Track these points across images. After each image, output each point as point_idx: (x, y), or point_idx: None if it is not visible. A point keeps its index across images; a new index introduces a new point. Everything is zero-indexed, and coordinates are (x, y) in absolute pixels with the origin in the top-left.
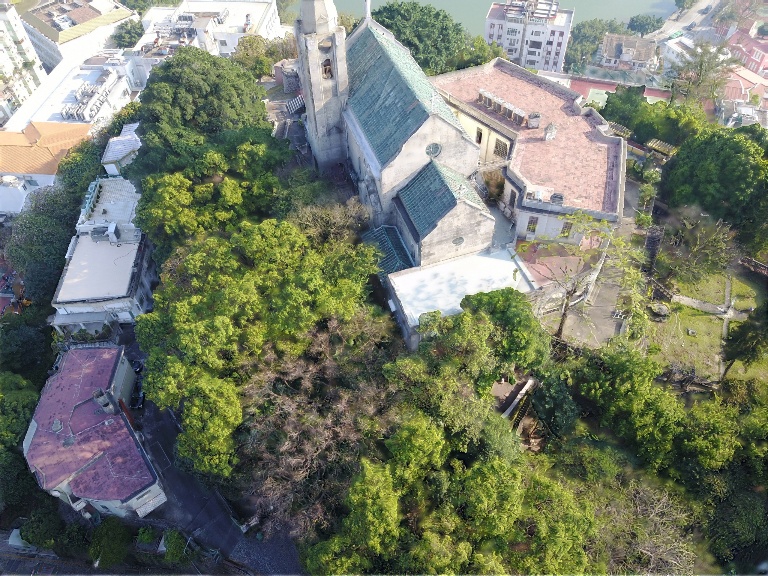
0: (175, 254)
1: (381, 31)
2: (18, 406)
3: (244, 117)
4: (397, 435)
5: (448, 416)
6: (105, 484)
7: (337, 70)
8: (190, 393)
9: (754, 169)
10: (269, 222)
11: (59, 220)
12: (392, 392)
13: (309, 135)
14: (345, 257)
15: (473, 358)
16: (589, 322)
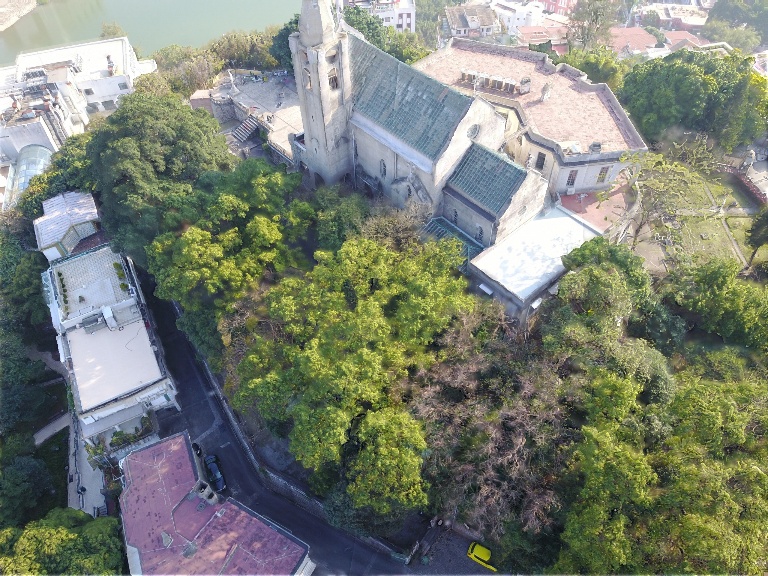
0: (224, 312)
1: (353, 33)
2: (105, 538)
3: (216, 154)
4: (595, 397)
5: (625, 364)
6: (257, 575)
7: (343, 78)
8: (365, 436)
9: (702, 86)
10: (348, 244)
11: (3, 328)
12: (563, 361)
13: (307, 153)
14: (431, 256)
15: (622, 305)
16: (675, 245)
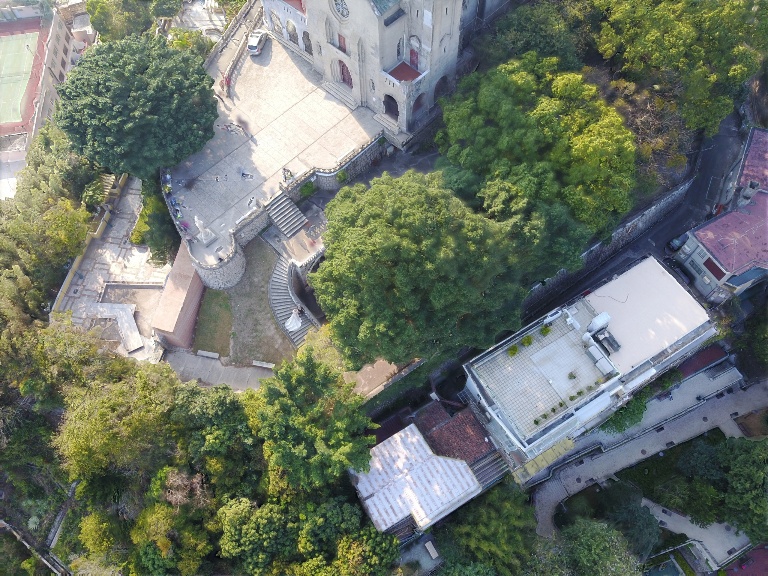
0: None
1: None
2: None
3: None
4: None
5: None
6: None
7: None
8: None
9: None
10: None
11: None
12: None
13: None
14: None
15: None
16: None
